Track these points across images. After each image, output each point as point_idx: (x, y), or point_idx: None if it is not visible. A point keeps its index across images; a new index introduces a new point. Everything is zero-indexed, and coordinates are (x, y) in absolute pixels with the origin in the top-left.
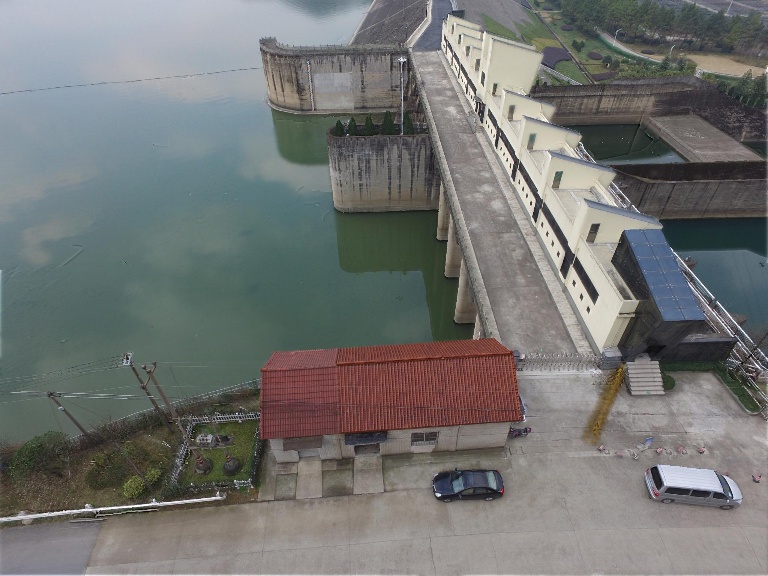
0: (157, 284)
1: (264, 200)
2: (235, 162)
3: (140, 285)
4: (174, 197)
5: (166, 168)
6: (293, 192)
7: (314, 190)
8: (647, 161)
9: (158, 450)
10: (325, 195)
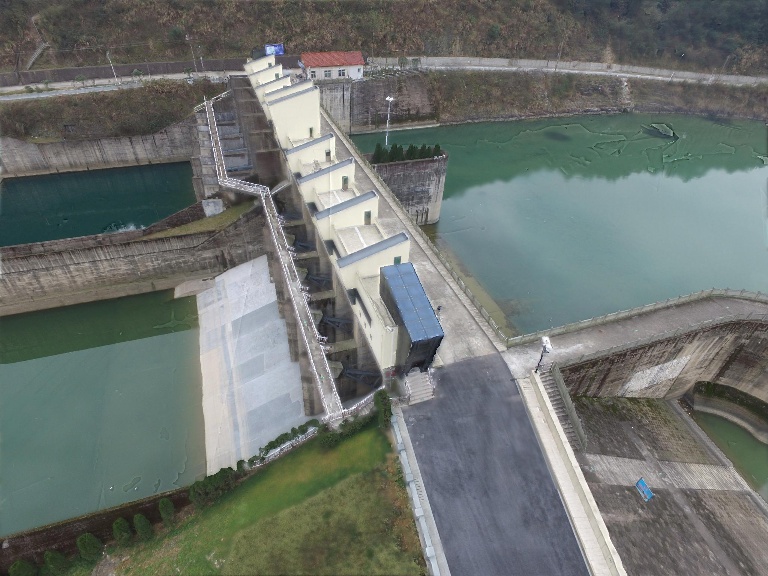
0: (492, 164)
1: (503, 218)
2: (594, 257)
3: (502, 165)
4: (579, 212)
5: (643, 238)
6: (487, 225)
7: (470, 229)
8: (0, 441)
9: (386, 73)
10: (456, 227)
